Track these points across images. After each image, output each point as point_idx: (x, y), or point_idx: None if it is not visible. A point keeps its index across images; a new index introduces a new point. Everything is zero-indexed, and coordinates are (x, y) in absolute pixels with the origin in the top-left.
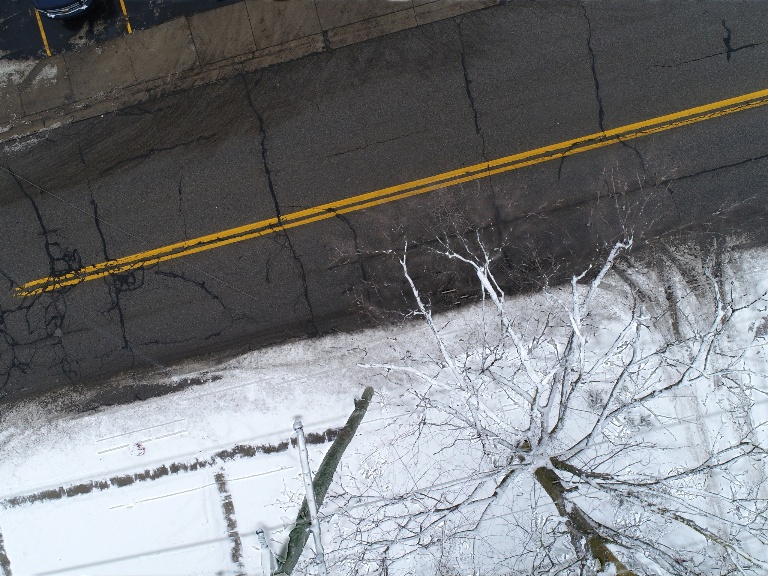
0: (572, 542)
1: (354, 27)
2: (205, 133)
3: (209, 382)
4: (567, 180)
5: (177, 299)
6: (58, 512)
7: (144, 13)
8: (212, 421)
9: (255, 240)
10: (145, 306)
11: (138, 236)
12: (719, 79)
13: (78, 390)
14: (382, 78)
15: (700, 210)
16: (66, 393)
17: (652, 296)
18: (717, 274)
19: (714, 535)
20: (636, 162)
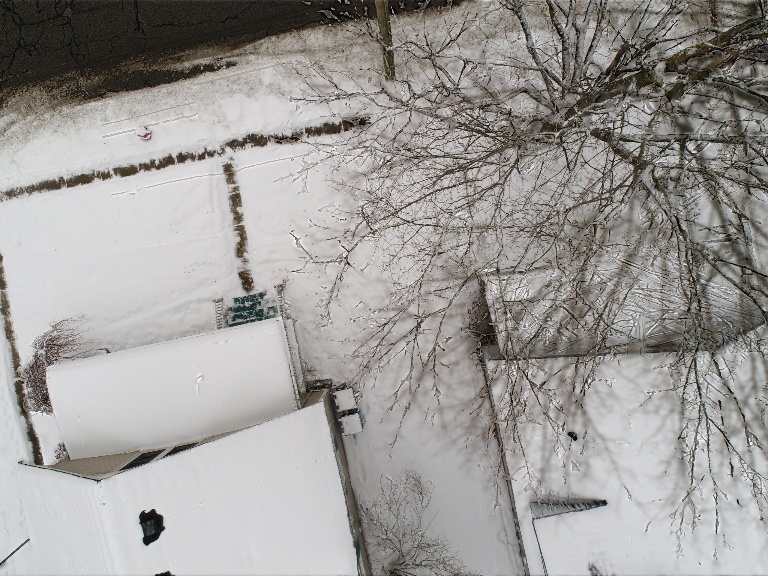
0: (606, 141)
1: None
2: None
3: (223, 68)
4: None
5: None
6: (57, 200)
7: None
8: (224, 104)
9: None
10: None
11: None
12: None
13: (85, 74)
14: None
15: None
16: (72, 77)
17: None
18: None
19: None
20: None
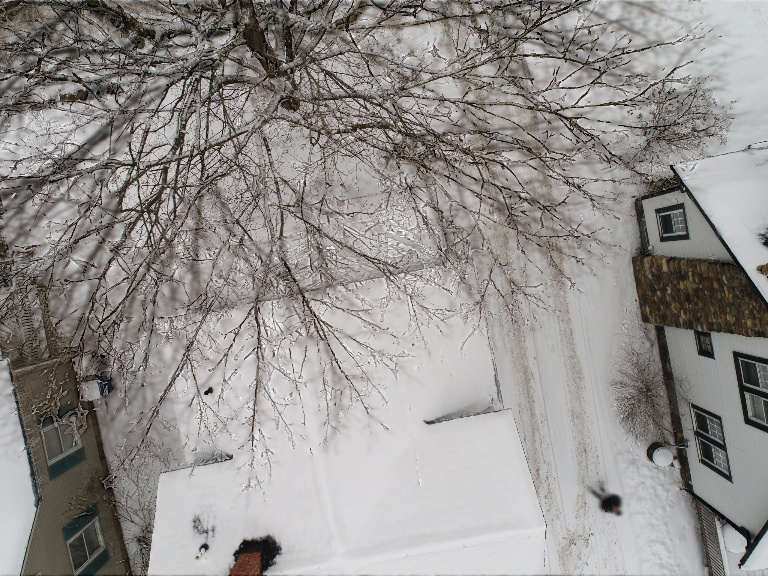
0: None
1: None
2: None
3: None
4: None
5: None
6: None
7: None
8: None
9: None
10: None
11: None
12: None
13: None
14: None
15: None
16: None
17: None
18: None
19: None
20: None
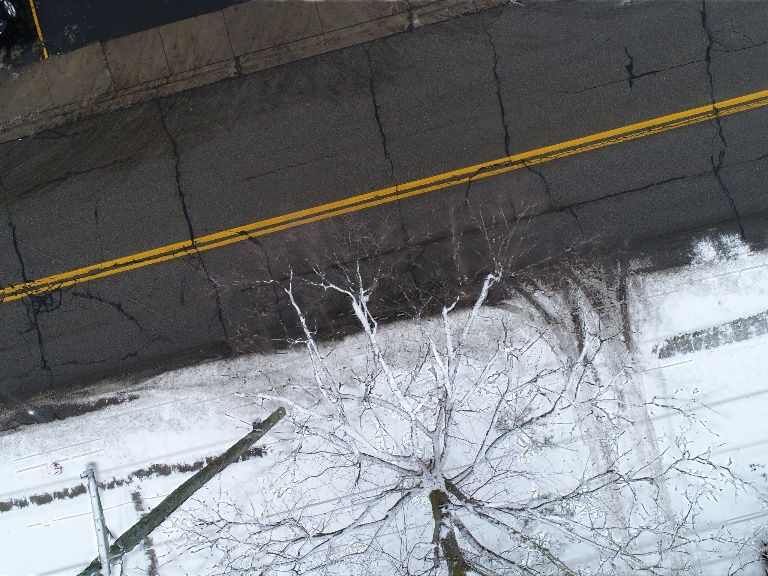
0: None
1: (265, 53)
2: (120, 157)
3: (126, 402)
4: (474, 204)
5: (94, 320)
6: None
7: (60, 39)
8: (128, 441)
9: (170, 262)
10: (63, 327)
11: (55, 258)
12: (622, 105)
13: None
14: (293, 103)
15: (604, 234)
16: None
17: (558, 318)
18: (622, 297)
19: (563, 565)
20: (541, 187)
